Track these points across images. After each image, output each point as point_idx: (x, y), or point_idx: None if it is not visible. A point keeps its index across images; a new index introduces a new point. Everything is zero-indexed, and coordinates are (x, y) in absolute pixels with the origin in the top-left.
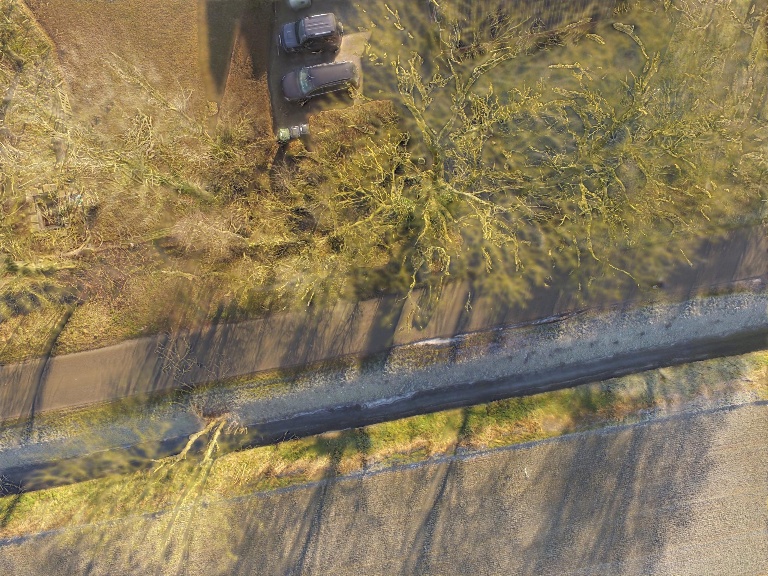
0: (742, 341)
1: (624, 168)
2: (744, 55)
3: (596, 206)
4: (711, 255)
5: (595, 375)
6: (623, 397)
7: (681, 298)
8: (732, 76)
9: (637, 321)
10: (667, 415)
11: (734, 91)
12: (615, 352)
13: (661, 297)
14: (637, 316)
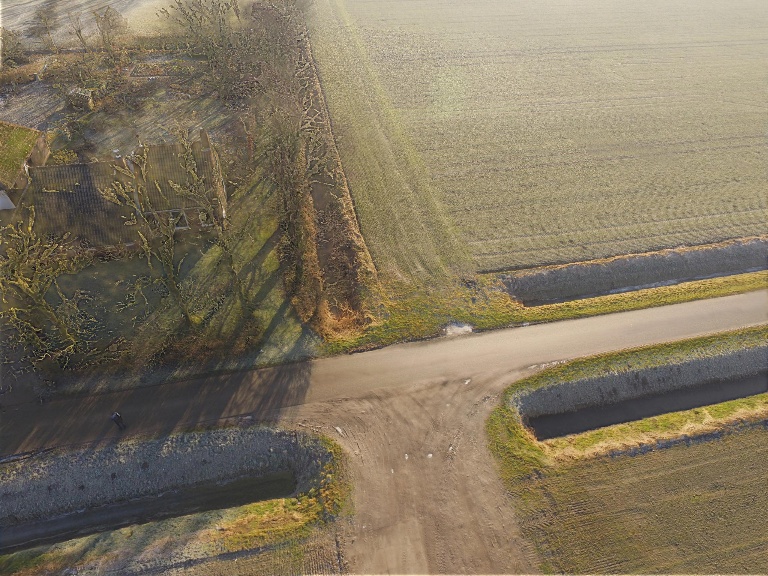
0: (243, 491)
1: (139, 329)
2: (258, 264)
3: (8, 315)
4: (203, 395)
5: (52, 536)
6: (61, 557)
7: (162, 435)
8: (246, 275)
9: (106, 459)
10: (98, 575)
11: (247, 283)
12: (84, 504)
13: (141, 434)
14: (107, 454)
